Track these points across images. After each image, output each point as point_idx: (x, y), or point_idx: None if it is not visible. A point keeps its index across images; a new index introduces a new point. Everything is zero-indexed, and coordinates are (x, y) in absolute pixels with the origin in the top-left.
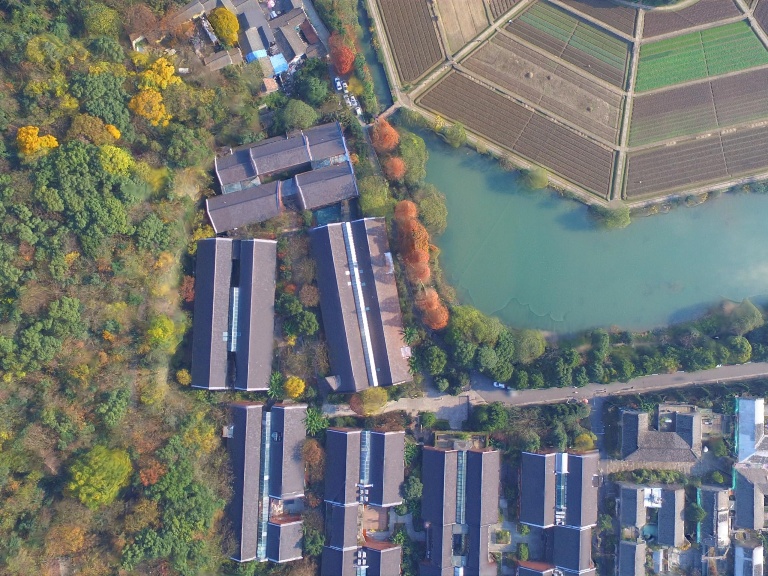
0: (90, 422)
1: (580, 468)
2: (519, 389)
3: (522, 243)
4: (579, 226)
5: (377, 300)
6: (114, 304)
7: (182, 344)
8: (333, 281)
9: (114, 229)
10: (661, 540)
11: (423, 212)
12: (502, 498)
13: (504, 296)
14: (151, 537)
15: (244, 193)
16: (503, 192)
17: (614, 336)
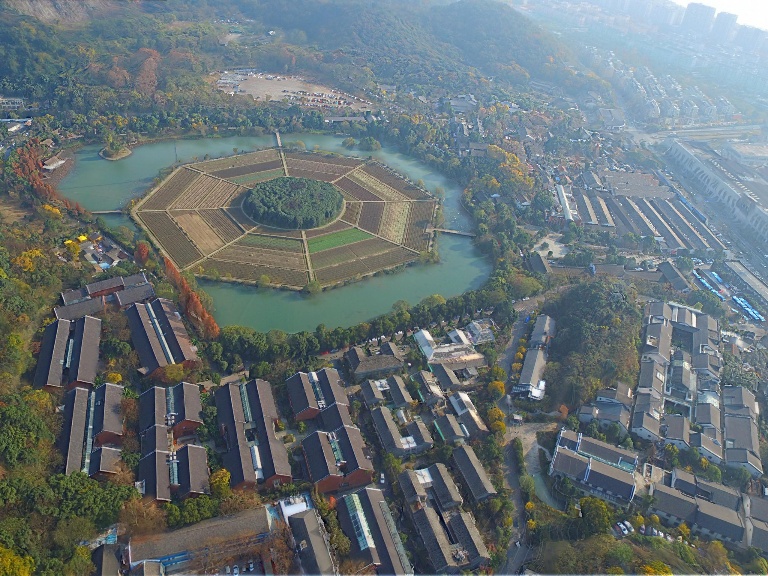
0: None
1: (325, 374)
2: (277, 359)
3: (265, 312)
4: (297, 299)
5: (171, 326)
6: None
7: (26, 380)
8: (140, 324)
9: None
10: (398, 404)
11: None
12: (282, 418)
13: None
14: None
15: None
16: (248, 294)
17: None
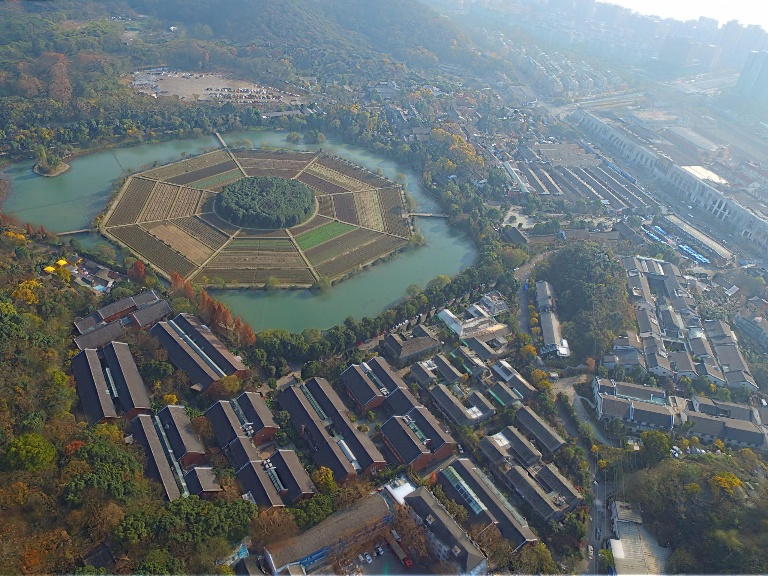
0: None
1: (377, 363)
2: (320, 356)
3: (283, 313)
4: (309, 297)
5: (206, 340)
6: None
7: None
8: (174, 342)
9: (15, 334)
10: (451, 380)
11: None
12: None
13: None
14: None
15: None
16: (259, 299)
17: None
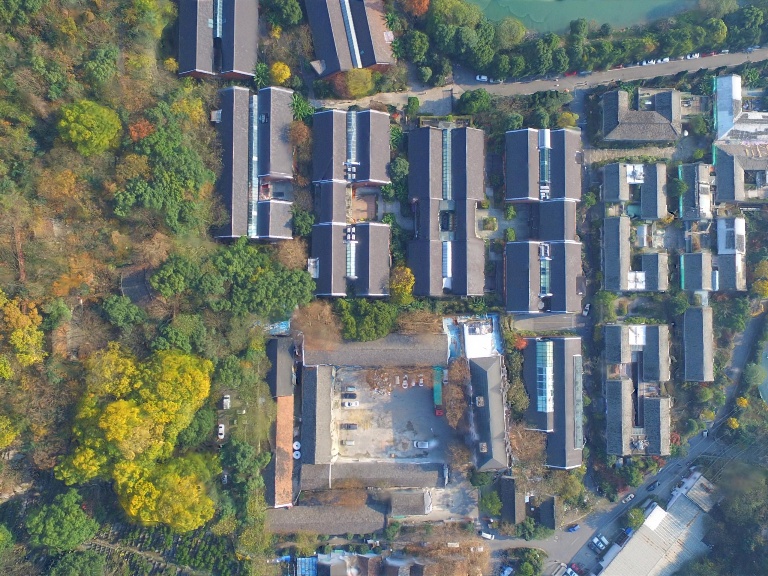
0: (79, 78)
1: (562, 141)
2: (501, 77)
3: None
4: None
5: None
6: None
7: (169, 39)
8: None
9: None
10: (644, 214)
11: None
12: (488, 186)
13: (485, 7)
14: (142, 186)
15: None
16: None
17: (593, 32)
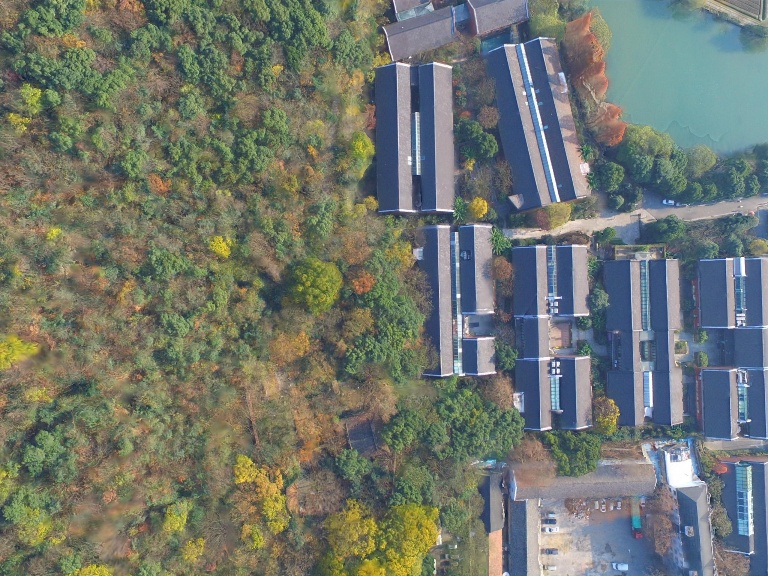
0: (302, 234)
1: (759, 269)
2: (690, 203)
3: (679, 67)
4: (733, 47)
5: (556, 117)
6: (314, 121)
7: (363, 174)
8: (512, 100)
9: (317, 40)
10: None
11: (593, 32)
12: None
13: (660, 124)
14: (370, 341)
15: (419, 19)
16: (659, 17)
17: None
